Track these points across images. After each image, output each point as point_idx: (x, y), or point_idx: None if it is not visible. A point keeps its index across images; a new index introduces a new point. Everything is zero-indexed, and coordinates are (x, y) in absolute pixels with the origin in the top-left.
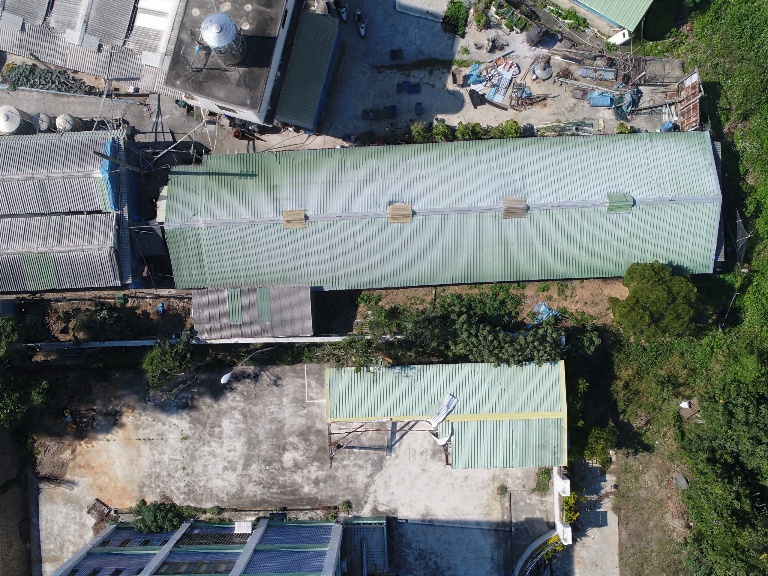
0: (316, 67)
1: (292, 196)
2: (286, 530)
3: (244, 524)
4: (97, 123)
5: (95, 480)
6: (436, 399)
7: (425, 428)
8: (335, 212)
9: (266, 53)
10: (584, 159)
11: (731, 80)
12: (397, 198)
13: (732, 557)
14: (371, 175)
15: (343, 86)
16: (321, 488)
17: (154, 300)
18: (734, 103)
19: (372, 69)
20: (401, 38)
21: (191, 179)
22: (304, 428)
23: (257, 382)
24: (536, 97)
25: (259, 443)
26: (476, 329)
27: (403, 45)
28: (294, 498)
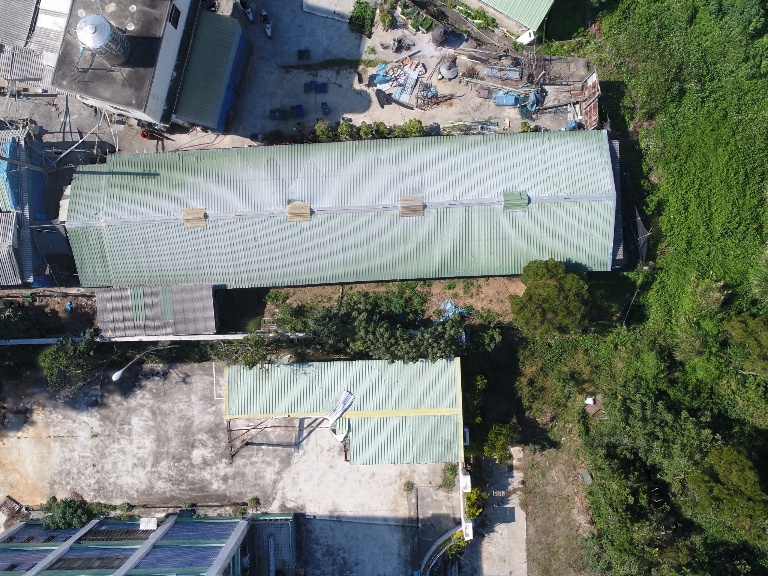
0: (216, 67)
1: (193, 195)
2: (192, 526)
3: (149, 520)
4: (5, 123)
5: (6, 477)
6: (333, 396)
7: None
8: (235, 211)
9: (151, 53)
10: (482, 158)
11: (635, 79)
12: (296, 197)
13: (625, 552)
14: (272, 174)
15: (251, 86)
16: (230, 485)
17: (62, 298)
18: (638, 102)
19: (280, 69)
20: (308, 38)
21: (95, 178)
22: (213, 425)
23: (166, 380)
24: (442, 96)
25: (168, 440)
26: (375, 326)
27: (310, 45)
28: (203, 495)
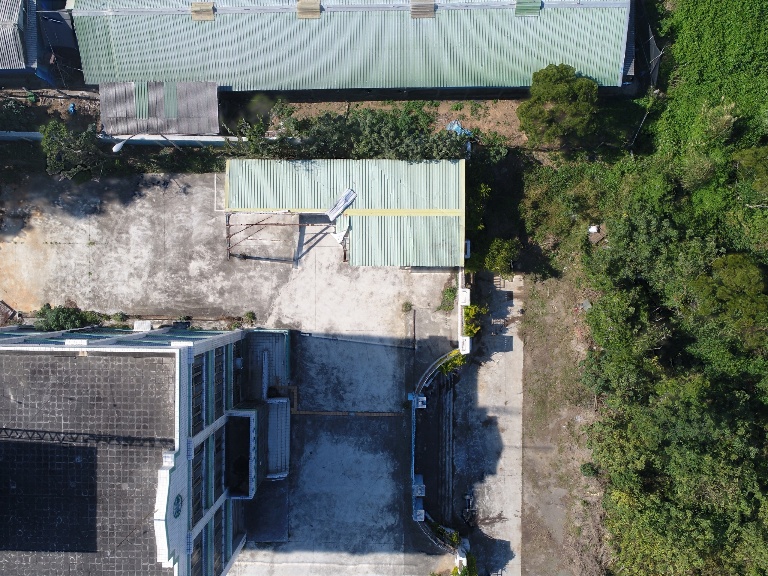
0: None
1: None
2: (186, 333)
3: (143, 323)
4: None
5: (1, 282)
6: (335, 193)
7: (332, 242)
8: (244, 5)
9: None
10: None
11: None
12: None
13: (624, 361)
14: None
15: None
16: (226, 298)
17: (65, 100)
18: None
19: None
20: None
21: None
22: (211, 237)
23: (166, 189)
24: None
25: (166, 251)
26: None
27: None
28: (198, 307)
